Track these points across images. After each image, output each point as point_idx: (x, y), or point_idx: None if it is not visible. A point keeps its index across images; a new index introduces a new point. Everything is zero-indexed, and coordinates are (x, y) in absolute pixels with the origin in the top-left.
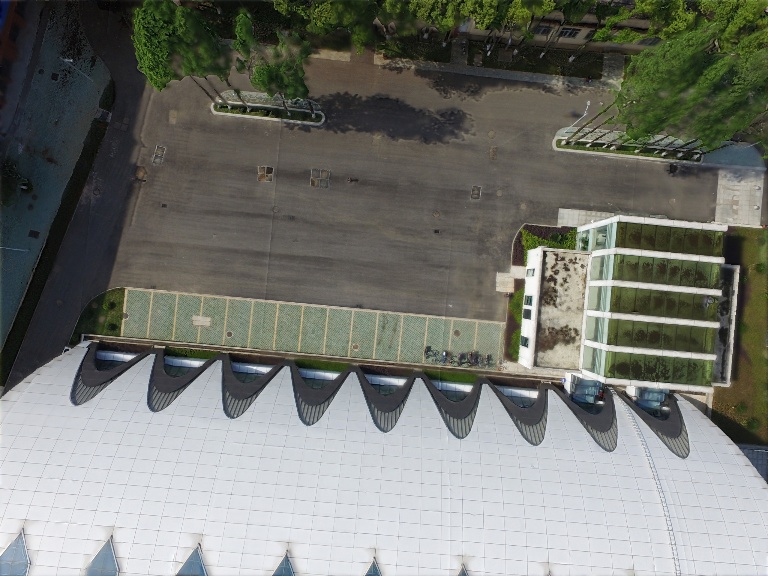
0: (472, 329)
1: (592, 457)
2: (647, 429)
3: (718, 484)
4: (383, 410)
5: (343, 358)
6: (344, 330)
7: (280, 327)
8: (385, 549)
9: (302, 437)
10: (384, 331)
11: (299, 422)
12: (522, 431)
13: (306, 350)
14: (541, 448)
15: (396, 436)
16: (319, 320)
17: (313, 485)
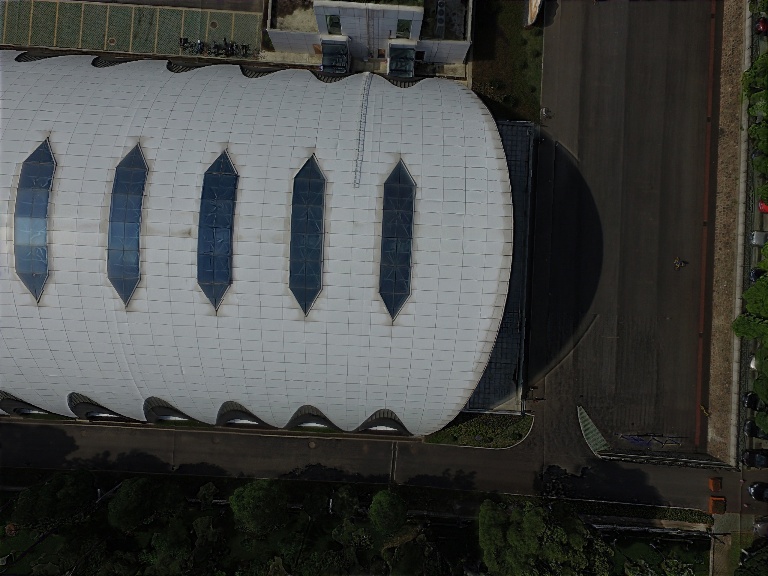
0: (229, 20)
1: (307, 84)
2: (380, 78)
3: (428, 99)
4: (107, 60)
5: (98, 51)
6: (100, 25)
7: (35, 23)
8: (60, 131)
9: (8, 66)
10: (140, 25)
11: (12, 60)
12: (246, 74)
13: (62, 45)
14: (257, 79)
15: (108, 69)
16: (74, 15)
17: (2, 90)
